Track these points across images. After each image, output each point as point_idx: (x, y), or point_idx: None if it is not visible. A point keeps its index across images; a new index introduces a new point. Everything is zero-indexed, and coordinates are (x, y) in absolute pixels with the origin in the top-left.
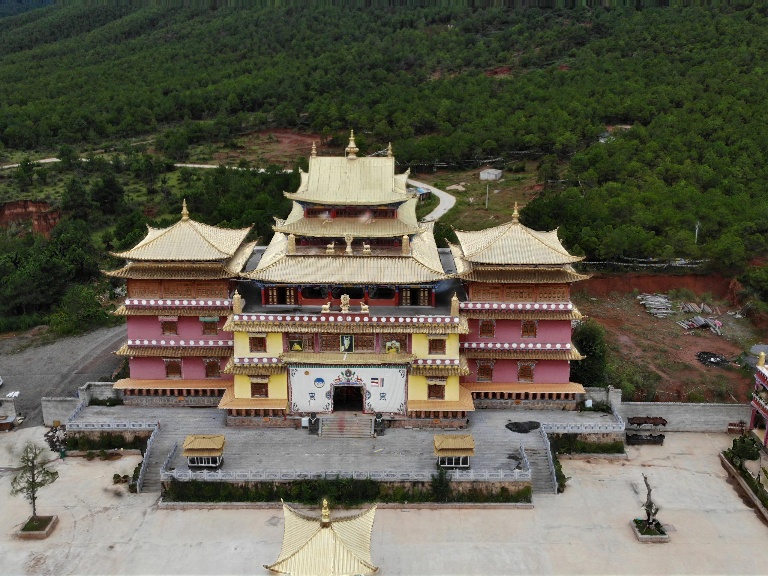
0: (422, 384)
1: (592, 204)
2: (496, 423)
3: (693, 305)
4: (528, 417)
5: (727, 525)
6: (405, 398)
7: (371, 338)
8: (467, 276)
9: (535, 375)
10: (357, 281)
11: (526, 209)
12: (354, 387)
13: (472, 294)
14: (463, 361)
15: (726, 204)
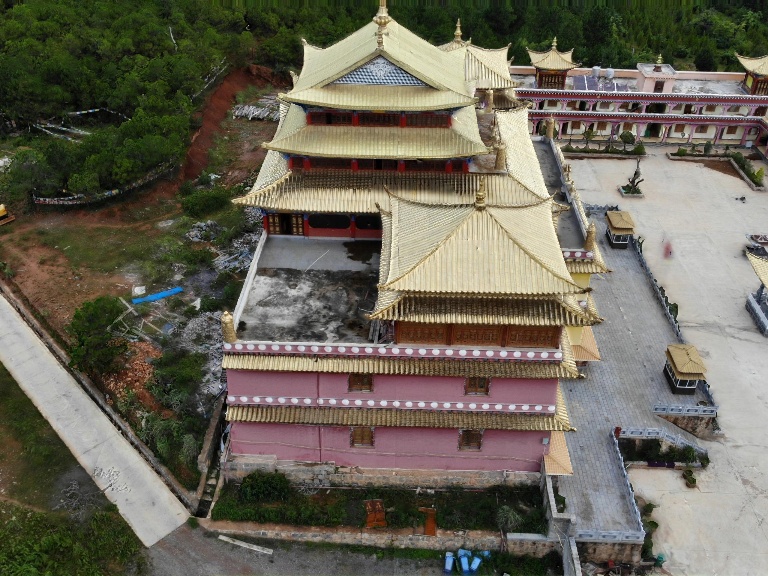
0: None
1: (56, 52)
2: None
3: (266, 100)
4: None
5: (609, 169)
6: None
7: None
8: None
9: None
10: None
11: (25, 88)
12: None
13: None
14: None
15: (106, 7)
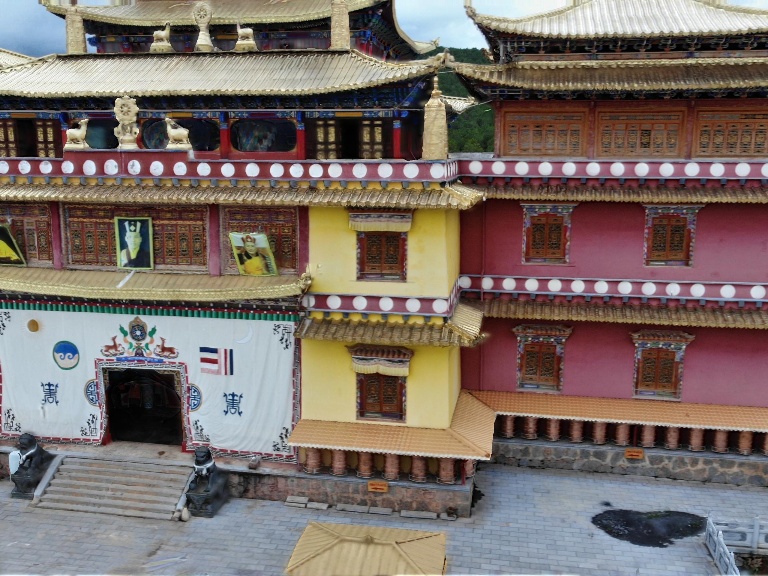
0: (340, 371)
1: None
2: (564, 508)
3: None
4: (665, 498)
5: None
6: (294, 412)
7: (198, 229)
8: (486, 73)
9: (686, 378)
10: (189, 88)
11: None
12: (157, 372)
13: (504, 137)
14: (469, 316)
15: None
